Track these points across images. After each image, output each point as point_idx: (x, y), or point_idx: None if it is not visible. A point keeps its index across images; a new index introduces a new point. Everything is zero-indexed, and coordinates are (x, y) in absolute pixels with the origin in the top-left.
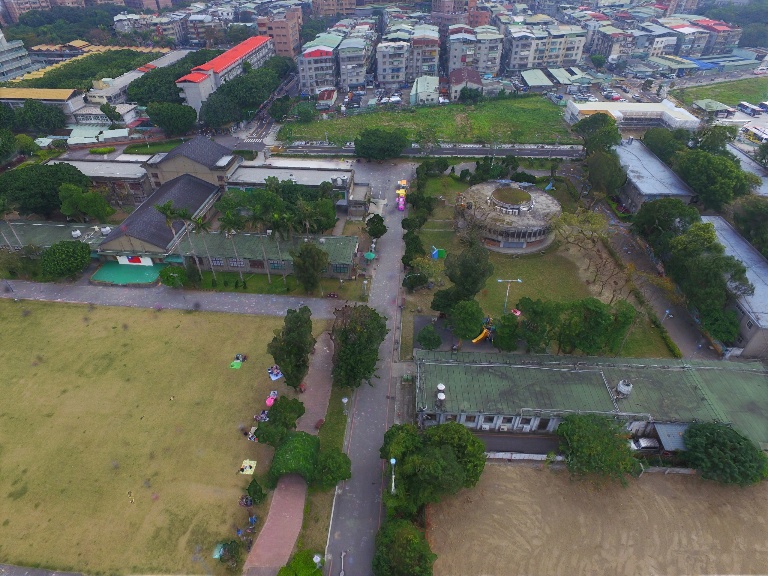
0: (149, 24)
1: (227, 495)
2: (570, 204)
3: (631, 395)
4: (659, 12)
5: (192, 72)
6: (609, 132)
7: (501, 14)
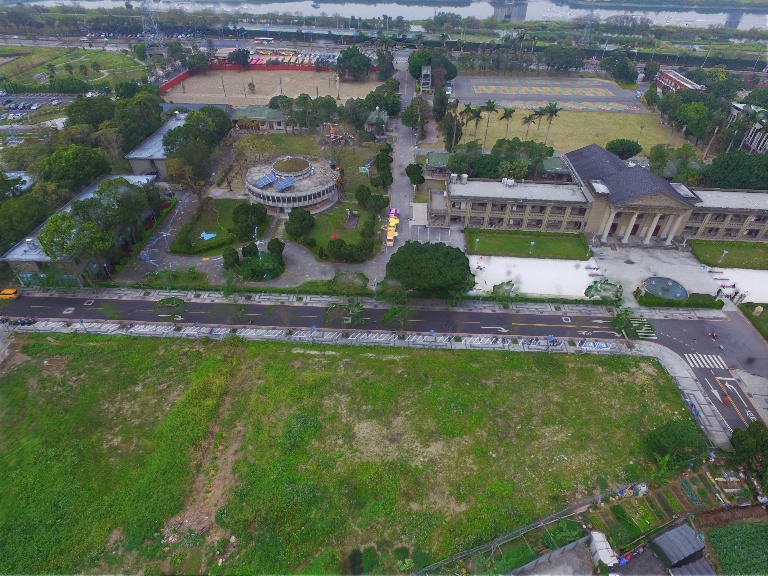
0: None
1: None
2: (207, 217)
3: None
4: None
5: None
6: None
7: None
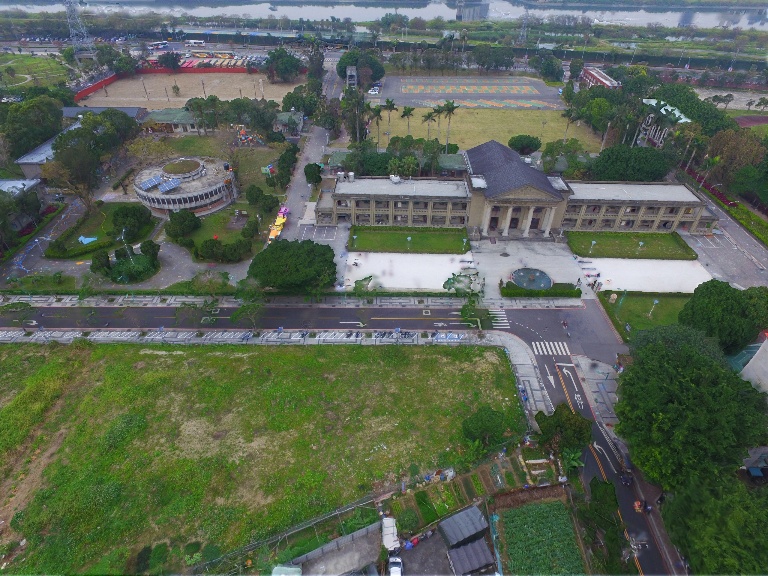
0: None
1: None
2: (94, 221)
3: None
4: None
5: None
6: None
7: None
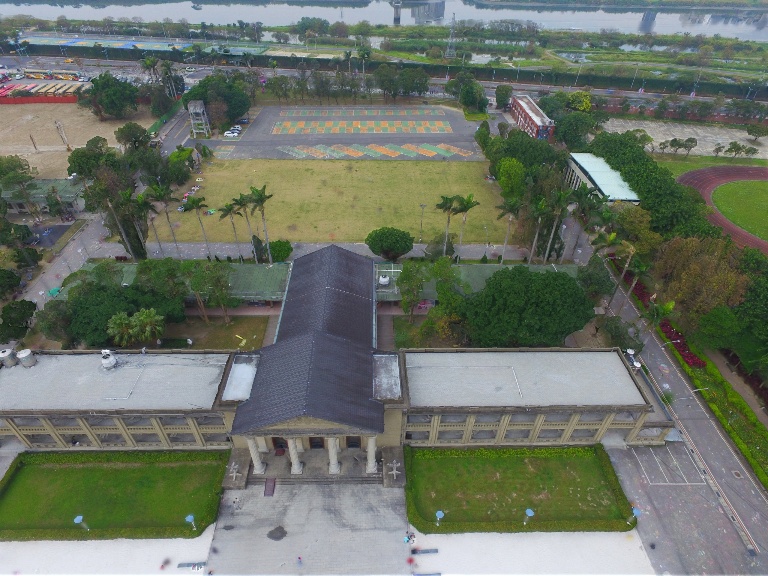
0: None
1: None
2: None
3: None
4: None
5: None
6: None
7: None
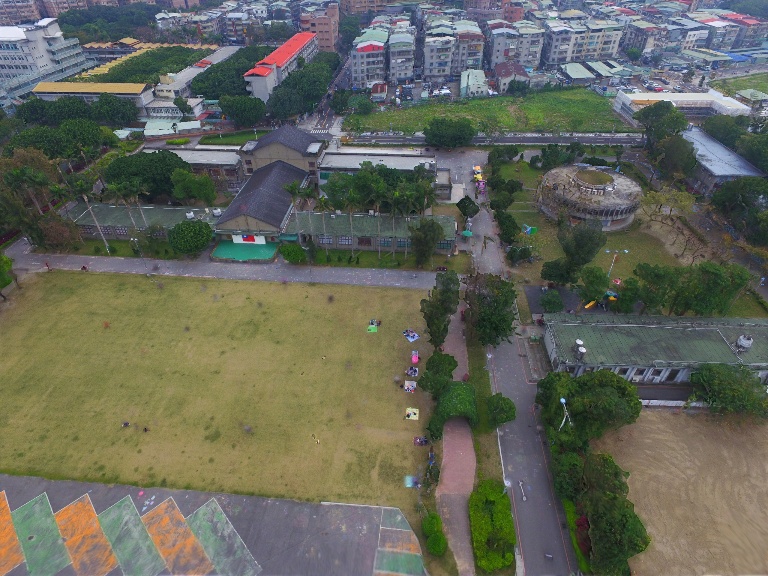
0: (190, 22)
1: (401, 437)
2: None
3: (750, 349)
4: (684, 7)
5: (257, 66)
6: (677, 118)
7: (534, 10)
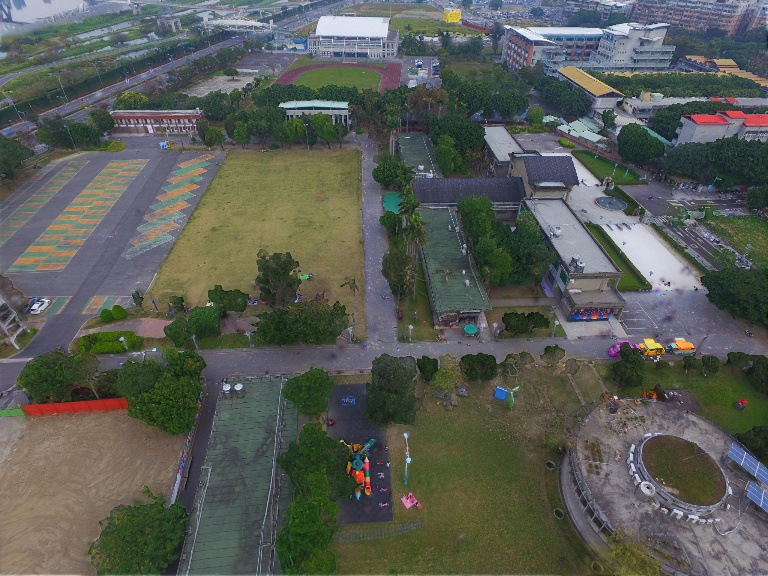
0: None
1: (193, 300)
2: None
3: None
4: None
5: (717, 114)
6: None
7: None
